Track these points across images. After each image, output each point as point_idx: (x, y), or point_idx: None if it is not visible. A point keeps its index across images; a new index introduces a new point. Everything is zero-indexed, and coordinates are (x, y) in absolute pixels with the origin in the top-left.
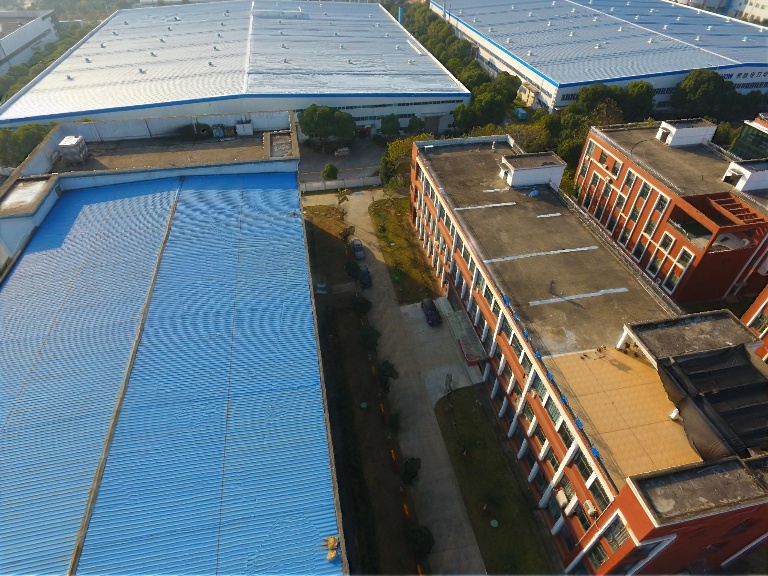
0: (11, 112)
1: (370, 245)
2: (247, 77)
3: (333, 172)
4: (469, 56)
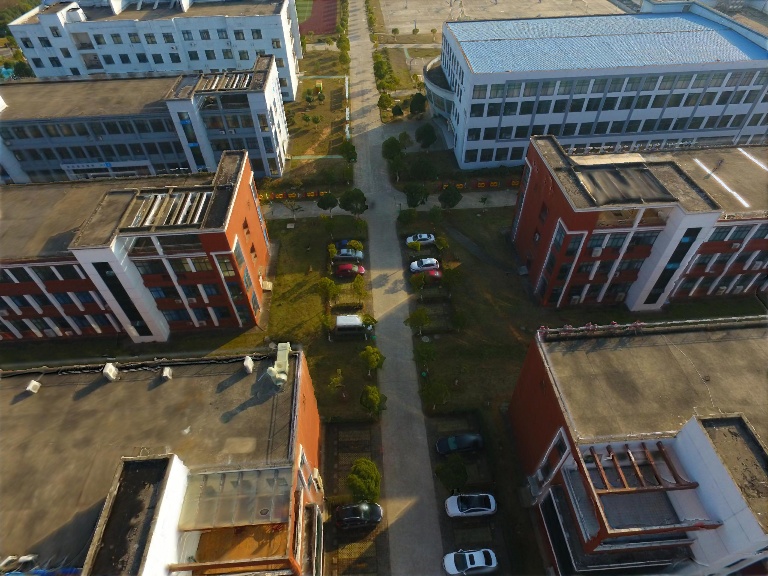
0: None
1: None
2: None
3: None
4: None
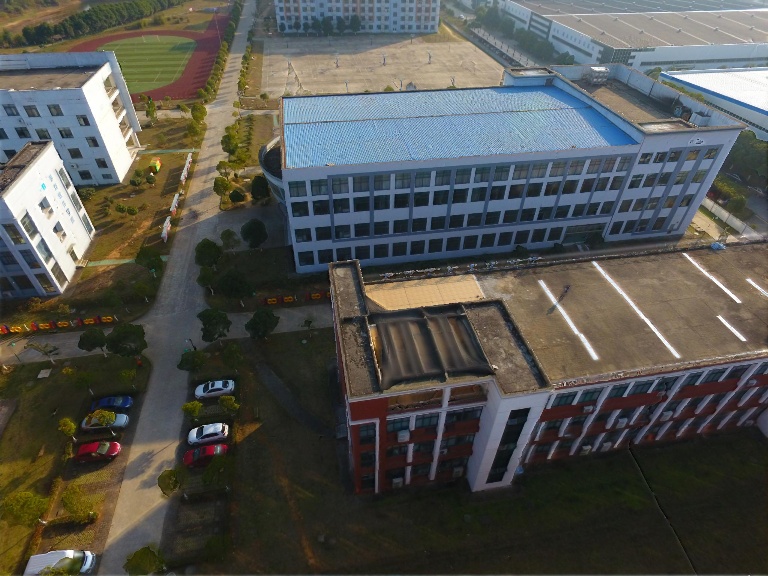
0: (685, 75)
1: None
2: None
3: None
4: None
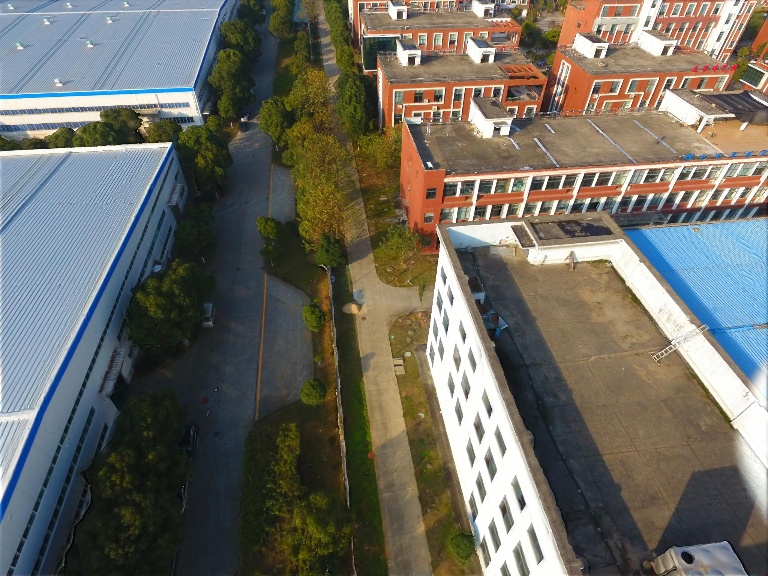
0: None
1: None
2: None
3: None
4: None
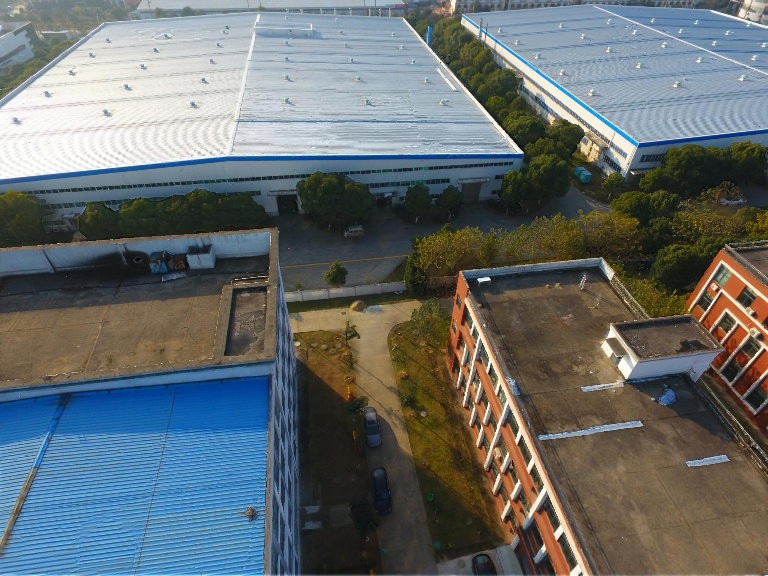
0: None
1: (390, 415)
2: (235, 127)
3: (340, 275)
4: (512, 90)
